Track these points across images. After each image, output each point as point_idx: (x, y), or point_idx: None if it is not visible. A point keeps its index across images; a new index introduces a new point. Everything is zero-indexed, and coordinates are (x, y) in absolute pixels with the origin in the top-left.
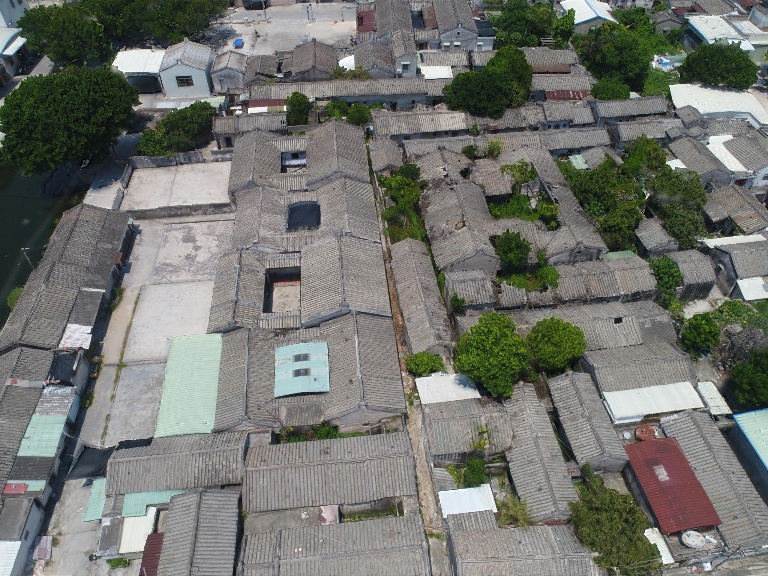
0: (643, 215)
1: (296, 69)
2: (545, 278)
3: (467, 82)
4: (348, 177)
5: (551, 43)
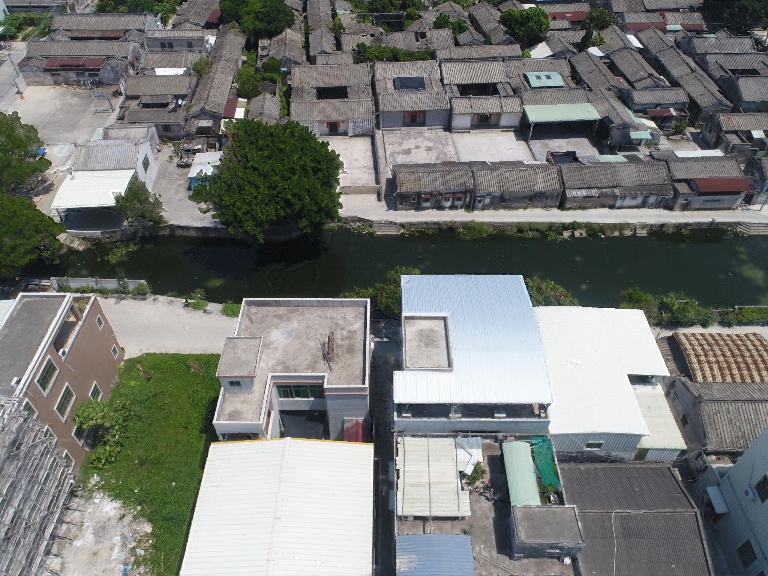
0: None
1: (177, 90)
2: (457, 26)
3: (274, 8)
4: None
5: (167, 5)
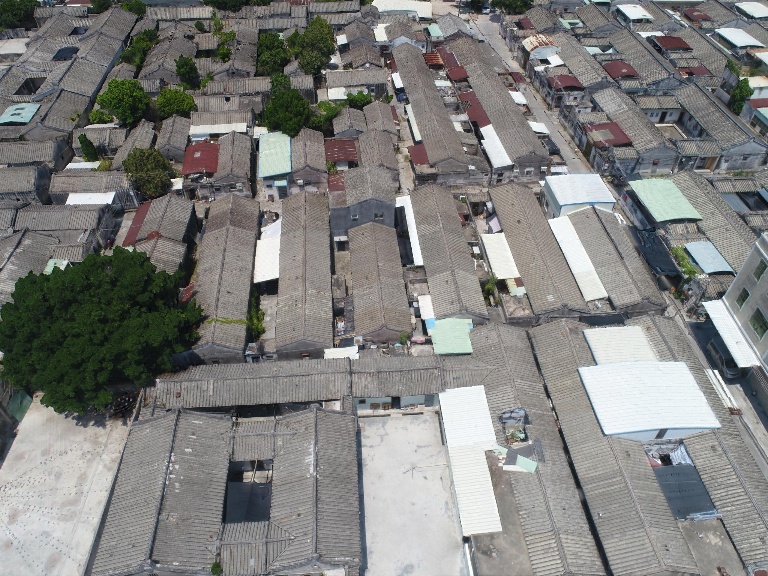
0: (294, 59)
1: None
2: None
3: None
4: (104, 34)
5: None
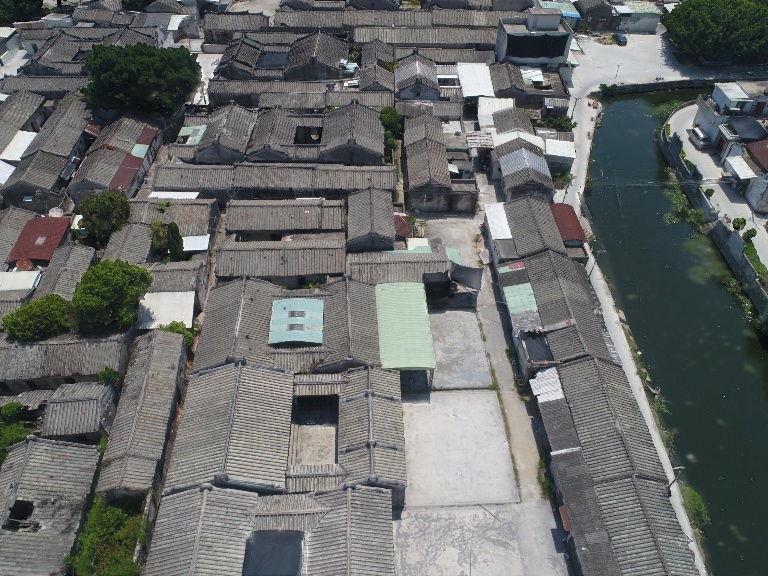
0: None
1: None
2: None
3: None
4: None
5: None
